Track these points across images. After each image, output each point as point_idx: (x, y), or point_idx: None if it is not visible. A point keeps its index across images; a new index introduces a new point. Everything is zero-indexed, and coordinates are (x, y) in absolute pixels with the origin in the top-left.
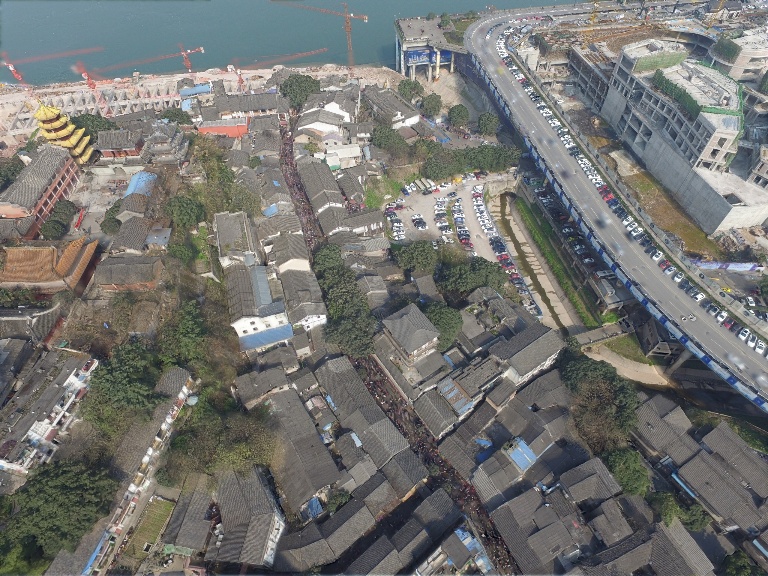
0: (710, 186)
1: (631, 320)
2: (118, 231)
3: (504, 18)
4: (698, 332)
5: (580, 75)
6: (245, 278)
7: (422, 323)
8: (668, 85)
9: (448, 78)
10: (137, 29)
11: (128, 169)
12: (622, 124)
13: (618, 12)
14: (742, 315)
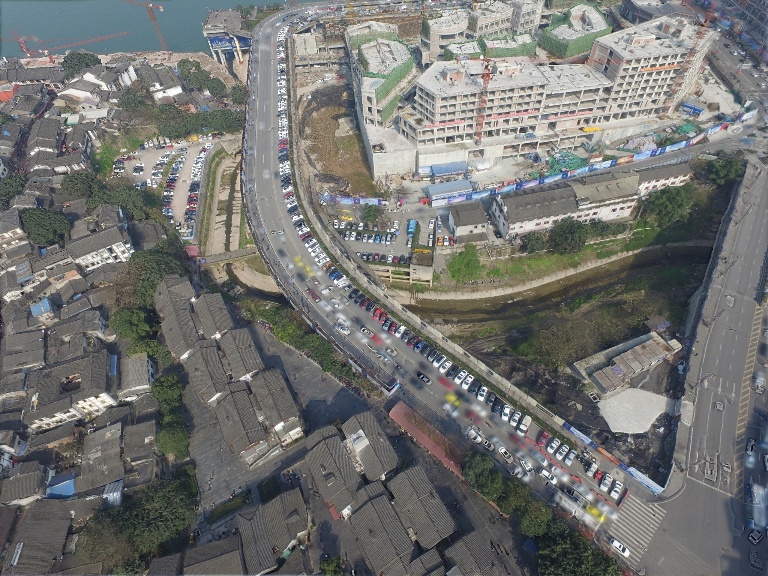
0: (368, 138)
1: None
2: None
3: (304, 9)
4: (276, 242)
5: None
6: None
7: (8, 219)
8: (361, 57)
9: None
10: (19, 24)
11: None
12: None
13: (407, 4)
14: (321, 230)
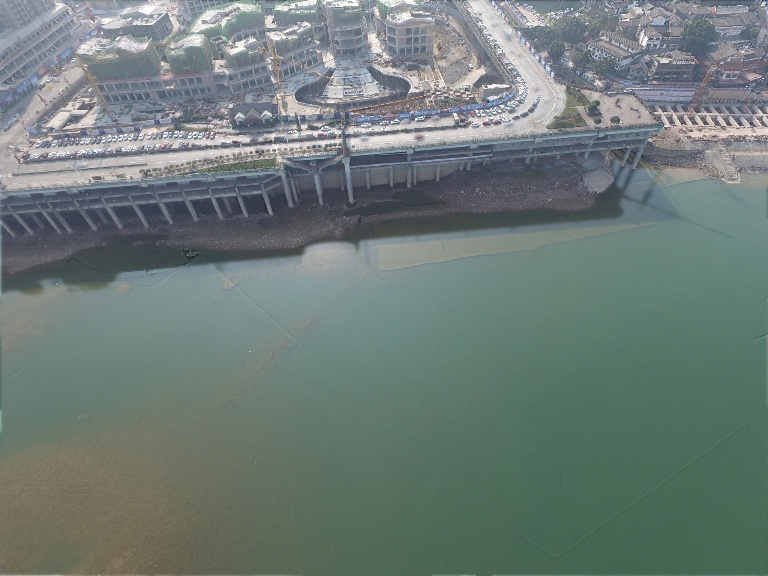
0: None
1: None
2: None
3: (516, 127)
4: None
5: None
6: None
7: None
8: None
9: None
10: None
11: None
12: None
13: None
14: None
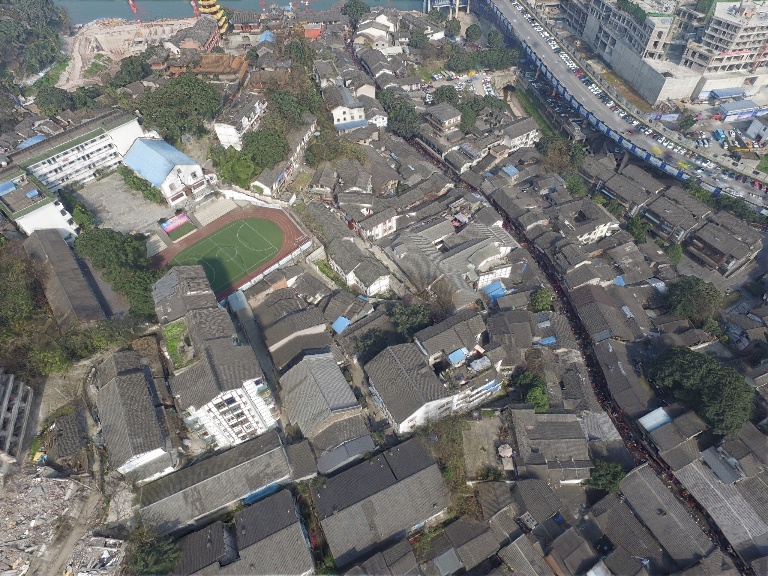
0: (653, 68)
1: (592, 149)
2: (257, 61)
3: None
4: (631, 139)
5: (568, 12)
6: (337, 92)
7: (451, 108)
8: (627, 4)
9: (465, 17)
10: None
11: (252, 37)
12: (597, 41)
13: None
14: (662, 132)
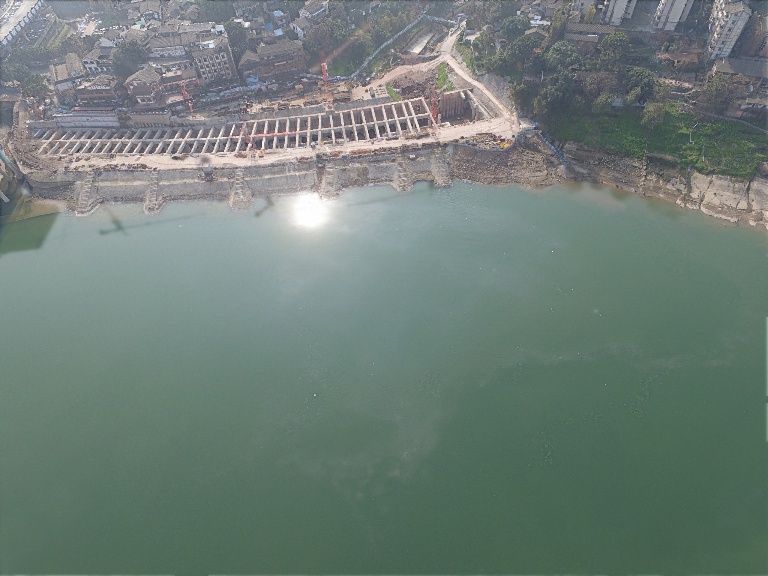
0: None
1: None
2: None
3: None
4: None
5: None
6: None
7: None
8: None
9: None
10: (392, 325)
11: None
12: None
13: None
14: None
